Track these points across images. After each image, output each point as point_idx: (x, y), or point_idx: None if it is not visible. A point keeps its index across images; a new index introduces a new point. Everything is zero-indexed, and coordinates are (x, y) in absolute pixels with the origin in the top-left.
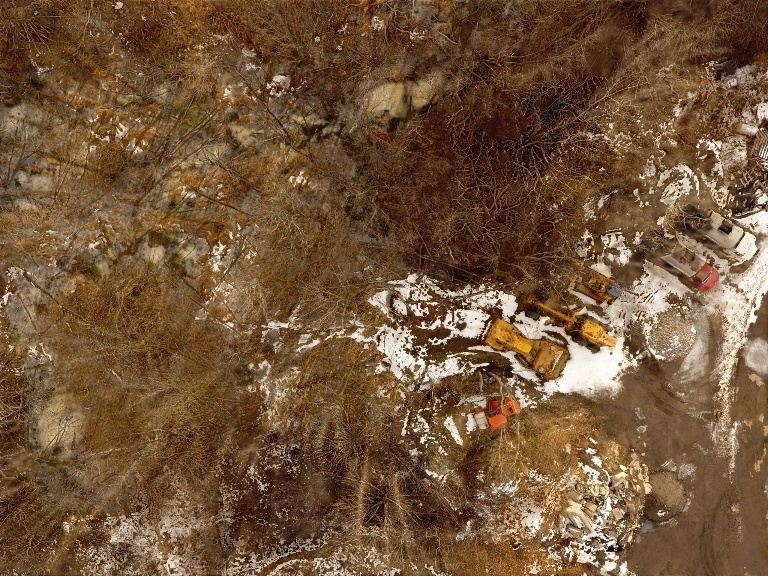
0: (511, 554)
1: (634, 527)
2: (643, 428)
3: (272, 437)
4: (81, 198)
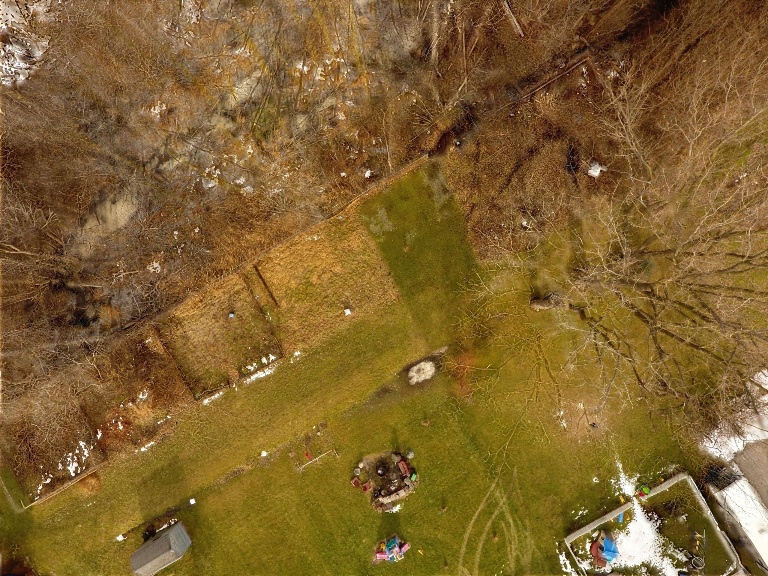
0: None
1: None
2: None
3: None
4: (328, 2)
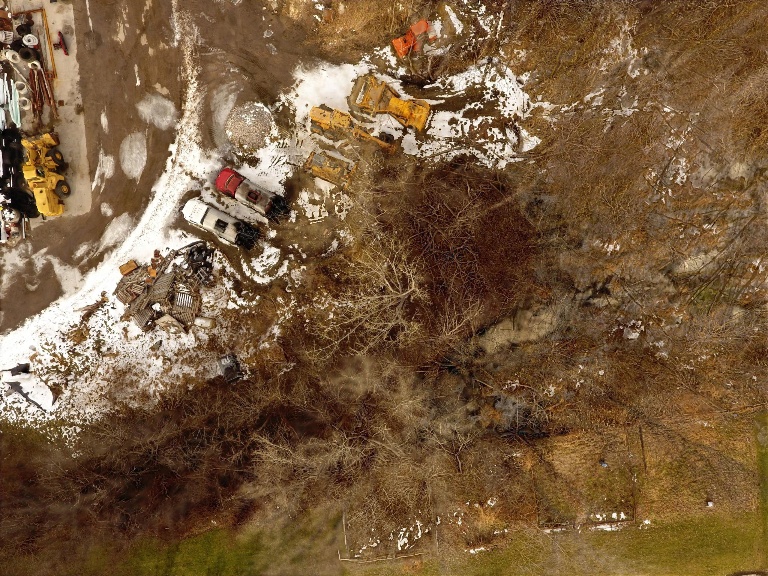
0: None
1: None
2: (267, 35)
3: (624, 5)
4: None
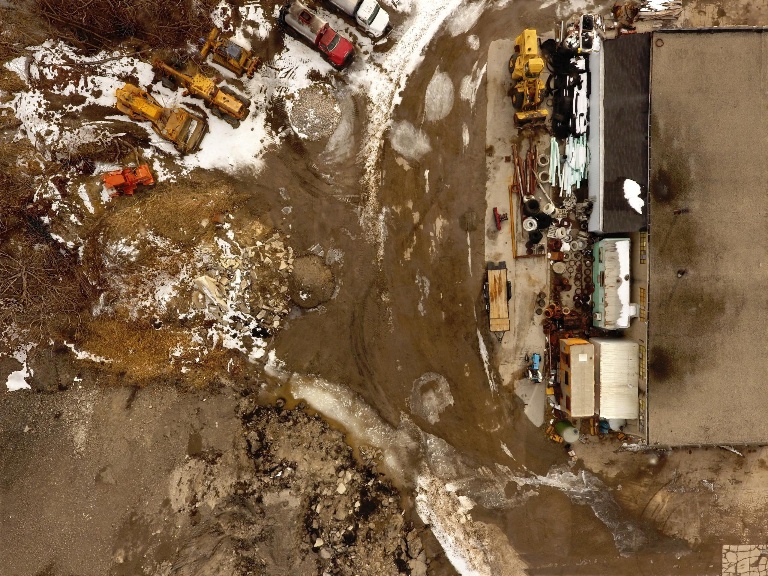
0: (153, 334)
1: (277, 310)
2: (288, 209)
3: None
4: None
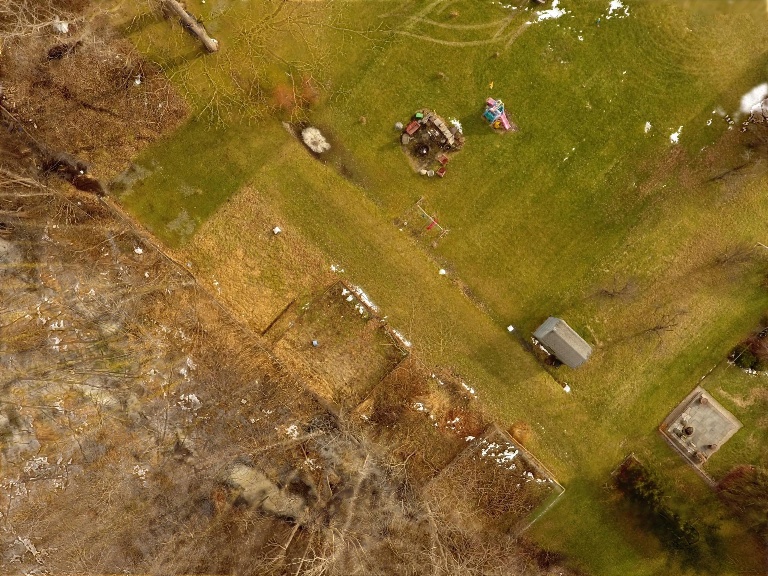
0: None
1: None
2: None
3: None
4: None
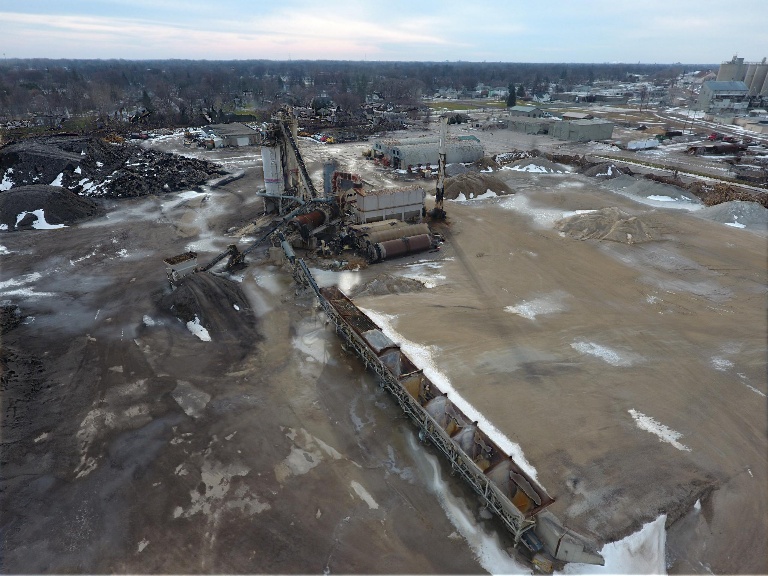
0: None
1: None
2: None
3: None
4: None
